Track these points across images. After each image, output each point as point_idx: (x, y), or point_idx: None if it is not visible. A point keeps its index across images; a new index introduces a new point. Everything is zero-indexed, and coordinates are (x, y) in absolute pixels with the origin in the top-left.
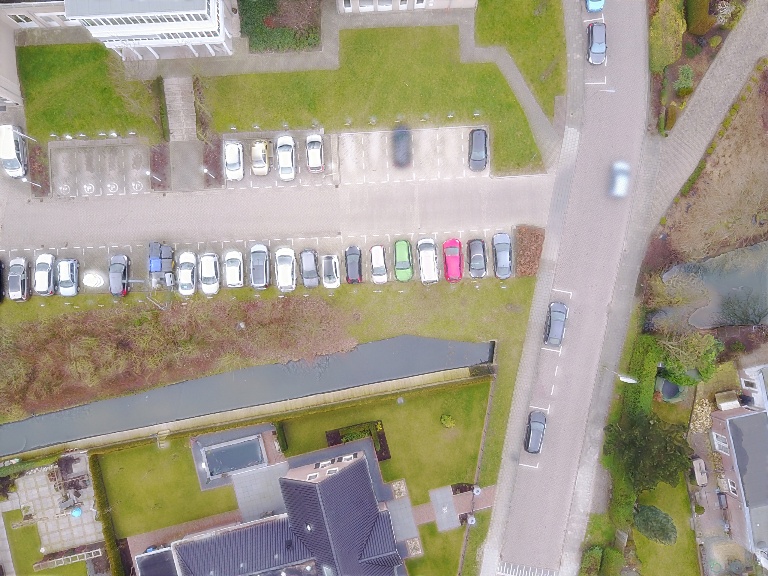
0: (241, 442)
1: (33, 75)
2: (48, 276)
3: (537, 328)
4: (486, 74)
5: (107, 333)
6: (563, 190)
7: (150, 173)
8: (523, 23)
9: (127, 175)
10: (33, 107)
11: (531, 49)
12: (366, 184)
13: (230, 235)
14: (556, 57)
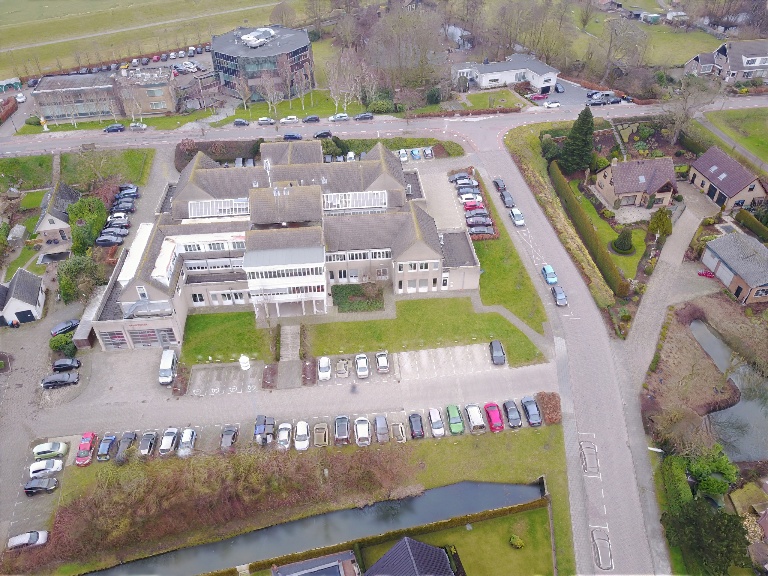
0: (321, 569)
1: (194, 328)
2: (173, 439)
3: (575, 460)
4: (493, 317)
5: (222, 453)
6: (564, 370)
7: (262, 379)
8: (510, 293)
9: (245, 381)
10: (188, 346)
11: (519, 304)
12: (420, 379)
13: (319, 413)
14: (536, 305)
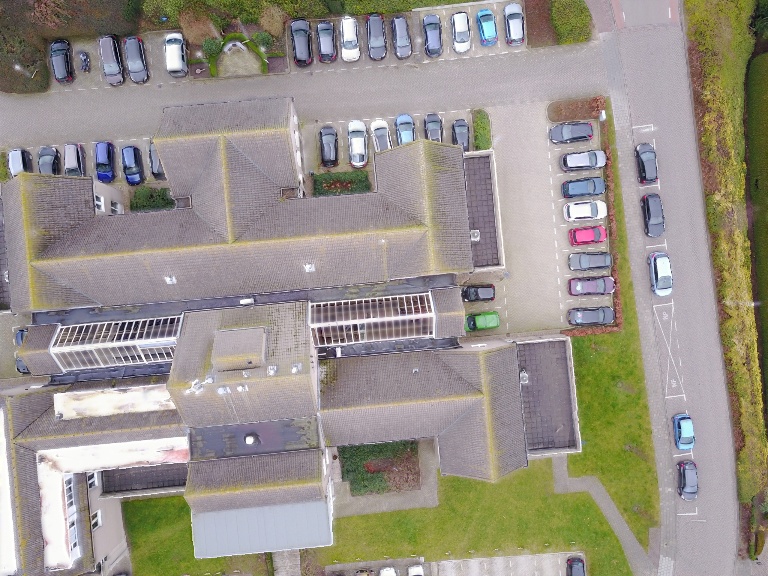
0: None
1: (139, 528)
2: None
3: None
4: (580, 503)
5: None
6: None
7: None
8: (614, 456)
9: None
10: (138, 553)
11: (623, 480)
12: None
13: None
14: (648, 490)
